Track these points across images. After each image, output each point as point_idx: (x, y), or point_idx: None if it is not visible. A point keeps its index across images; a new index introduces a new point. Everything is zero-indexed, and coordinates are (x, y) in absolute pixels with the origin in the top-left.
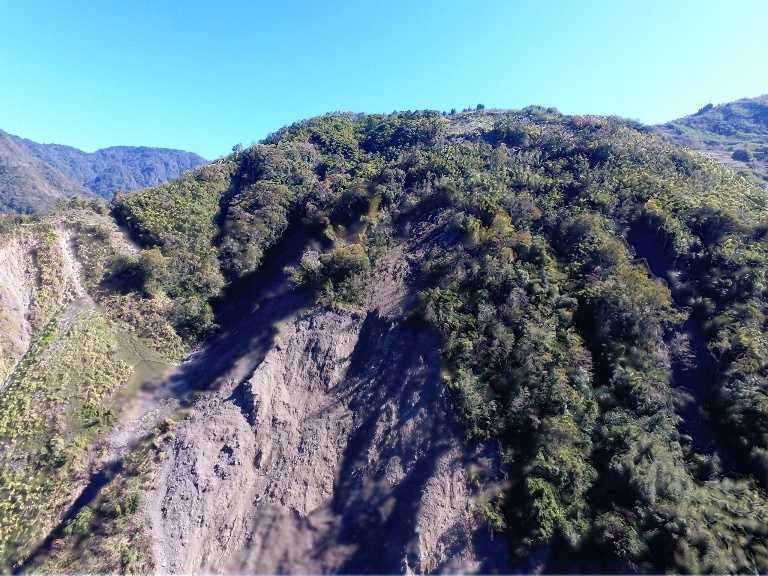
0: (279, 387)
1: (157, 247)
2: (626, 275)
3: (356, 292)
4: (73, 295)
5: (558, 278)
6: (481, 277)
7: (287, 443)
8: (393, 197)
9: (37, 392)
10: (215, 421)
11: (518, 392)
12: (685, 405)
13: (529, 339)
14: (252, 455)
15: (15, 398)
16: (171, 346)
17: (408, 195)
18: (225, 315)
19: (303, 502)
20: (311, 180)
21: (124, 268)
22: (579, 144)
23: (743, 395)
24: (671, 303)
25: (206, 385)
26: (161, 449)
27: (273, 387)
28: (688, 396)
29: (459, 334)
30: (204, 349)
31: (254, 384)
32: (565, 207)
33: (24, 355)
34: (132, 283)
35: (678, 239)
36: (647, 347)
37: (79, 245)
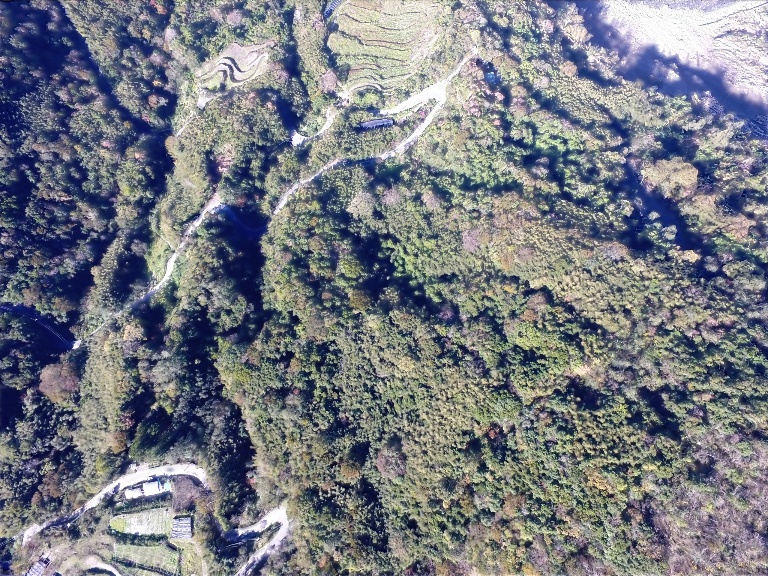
0: None
1: None
2: None
3: None
4: None
5: None
6: None
7: None
8: None
9: None
10: None
11: None
12: None
13: None
14: None
15: None
16: None
17: None
18: None
19: (764, 117)
20: None
21: None
22: None
23: None
24: None
25: None
26: None
27: None
28: None
29: None
30: None
31: None
32: None
33: None
34: None
35: None
36: None
37: None
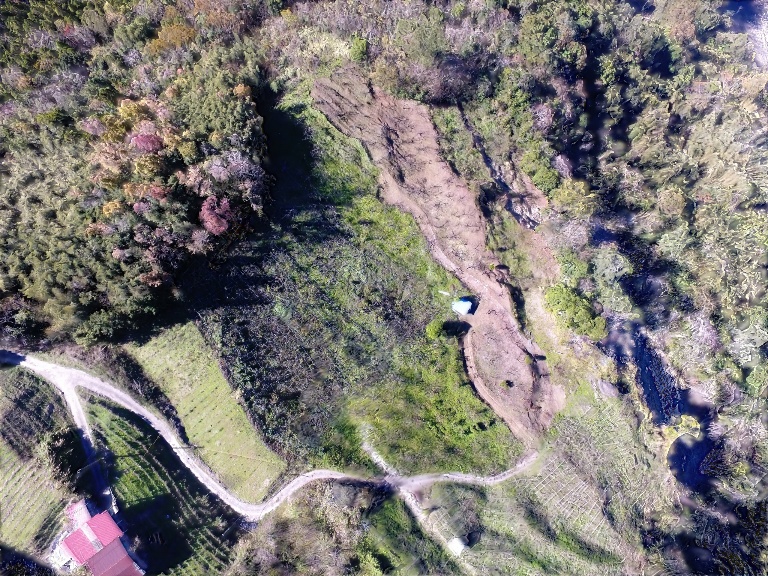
0: None
1: None
2: None
3: None
4: None
5: None
6: None
7: None
8: None
9: None
10: None
11: None
12: None
13: None
14: None
15: None
16: None
17: None
18: None
19: None
20: None
21: None
22: None
23: None
24: None
25: None
26: None
27: None
28: None
29: None
30: None
31: None
32: None
33: None
34: None
35: None
36: None
37: None
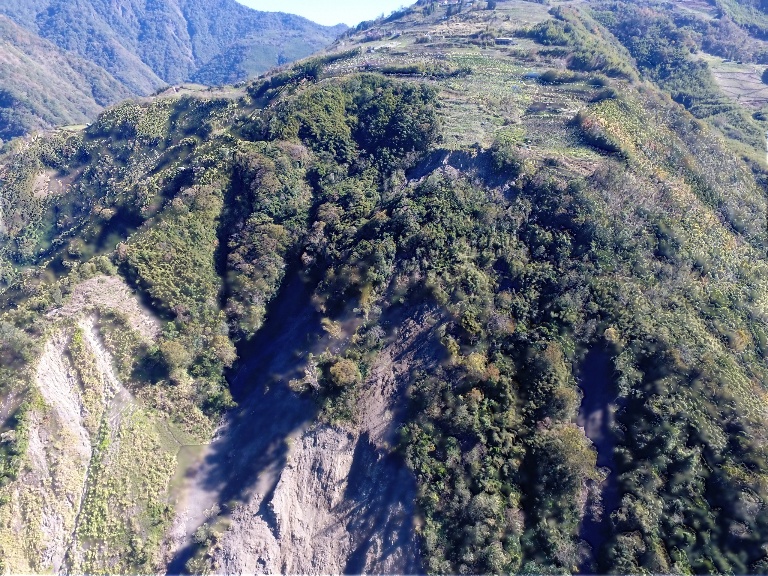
0: (294, 505)
1: (171, 323)
2: (566, 439)
3: (350, 409)
4: (112, 391)
5: (514, 424)
6: (452, 418)
7: (303, 556)
8: (384, 280)
9: (110, 498)
10: (250, 535)
11: (466, 551)
12: (582, 563)
13: (480, 502)
14: (279, 565)
15: (96, 505)
16: (201, 427)
17: (397, 279)
18: (240, 380)
19: None
20: (304, 195)
21: (148, 358)
22: (568, 209)
23: (622, 564)
24: (594, 473)
25: (237, 483)
26: (214, 558)
27: (289, 505)
28: (586, 555)
29: (429, 486)
30: (227, 423)
31: (275, 504)
32: (535, 328)
33: (90, 461)
34: (158, 372)
35: (623, 380)
36: (572, 490)
37: (104, 334)
